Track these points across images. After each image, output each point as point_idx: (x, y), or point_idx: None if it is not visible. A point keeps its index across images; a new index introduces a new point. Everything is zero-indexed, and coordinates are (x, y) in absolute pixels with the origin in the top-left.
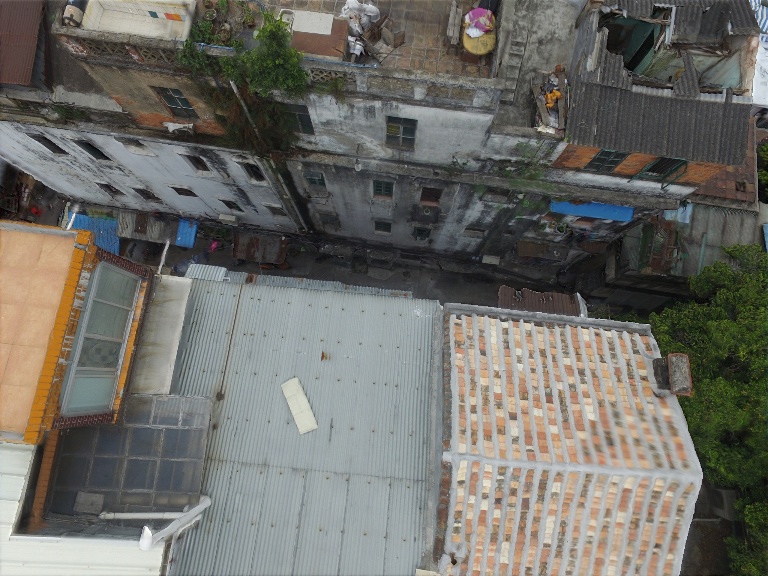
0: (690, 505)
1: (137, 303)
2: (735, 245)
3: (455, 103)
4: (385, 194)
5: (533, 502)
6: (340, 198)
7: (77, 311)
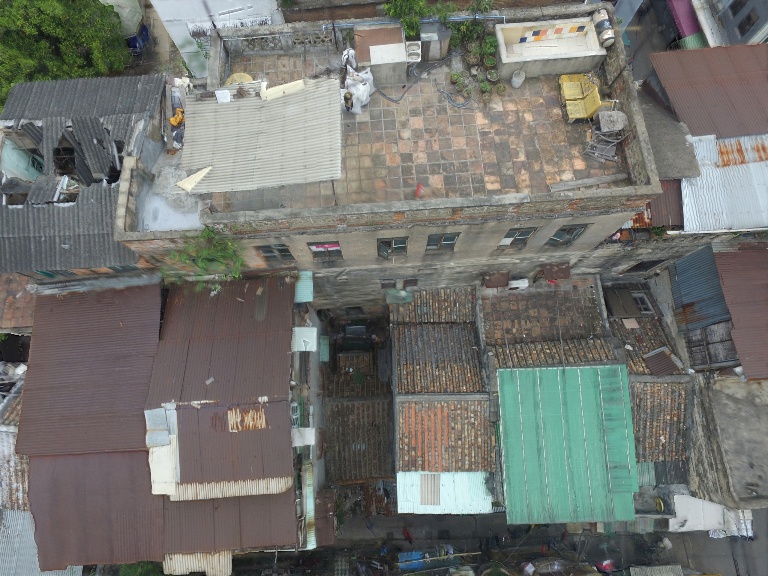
0: None
1: None
2: None
3: None
4: None
5: None
6: None
7: None
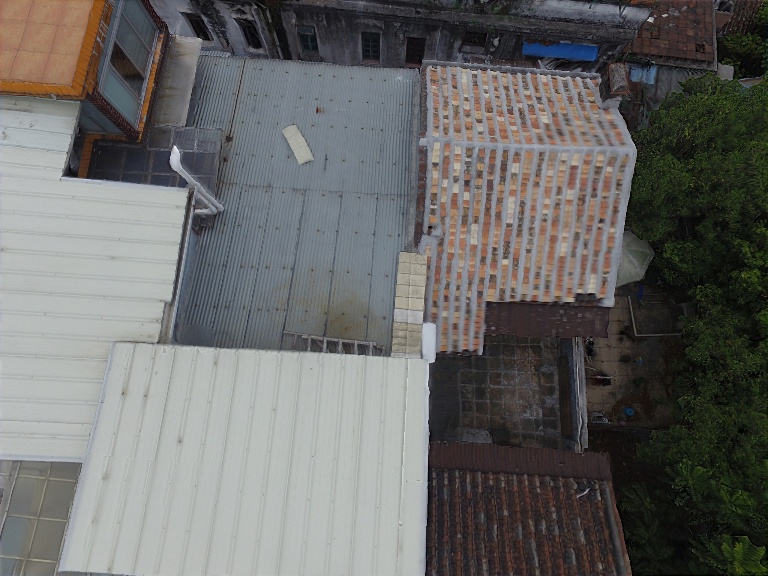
0: (627, 178)
1: (156, 49)
2: (690, 78)
3: None
4: (373, 57)
5: (496, 183)
6: None
7: (110, 7)
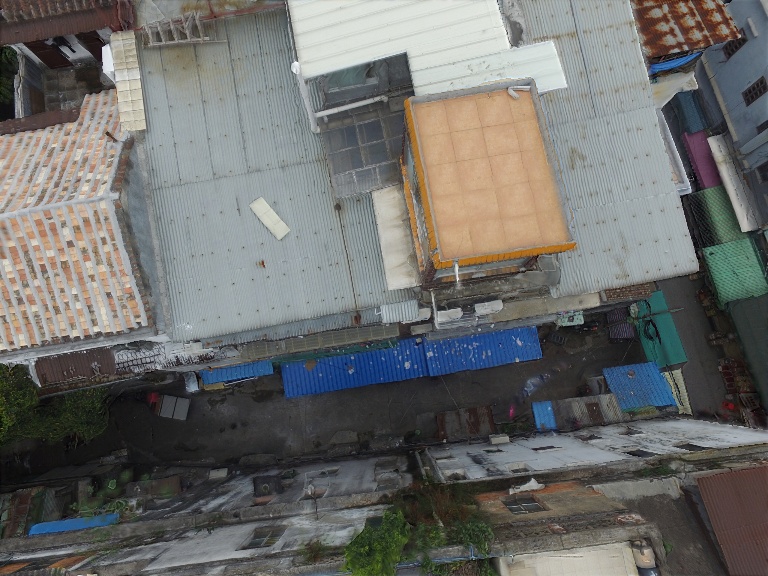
0: None
1: (421, 251)
2: None
3: (179, 572)
4: None
5: (51, 187)
6: None
7: None
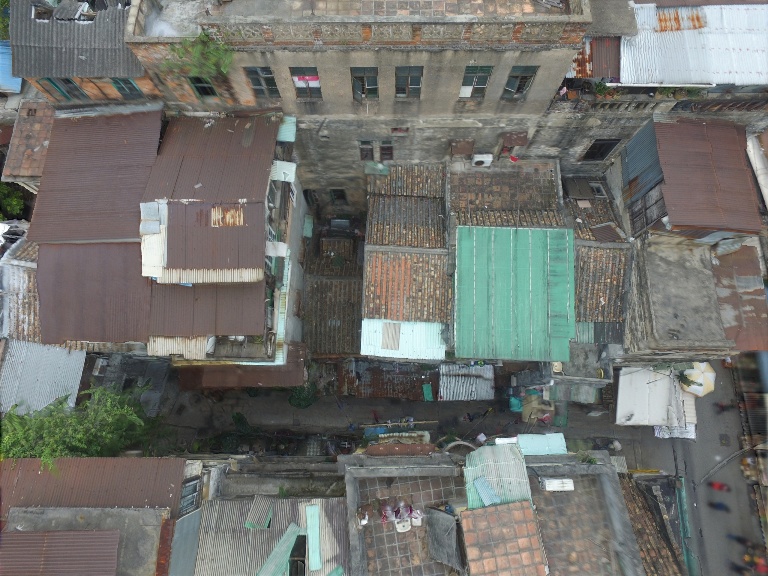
0: None
1: None
2: None
3: None
4: None
5: None
6: None
7: None
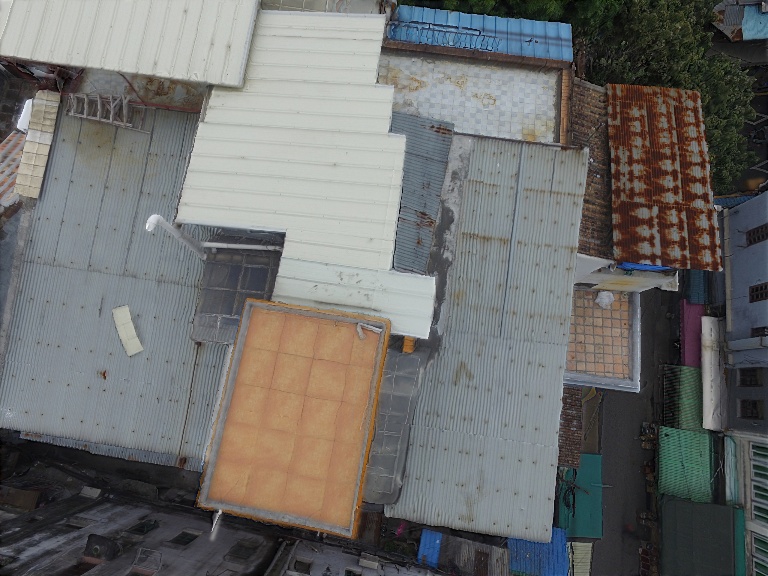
0: None
1: None
2: None
3: None
4: None
5: None
6: (199, 575)
7: None
